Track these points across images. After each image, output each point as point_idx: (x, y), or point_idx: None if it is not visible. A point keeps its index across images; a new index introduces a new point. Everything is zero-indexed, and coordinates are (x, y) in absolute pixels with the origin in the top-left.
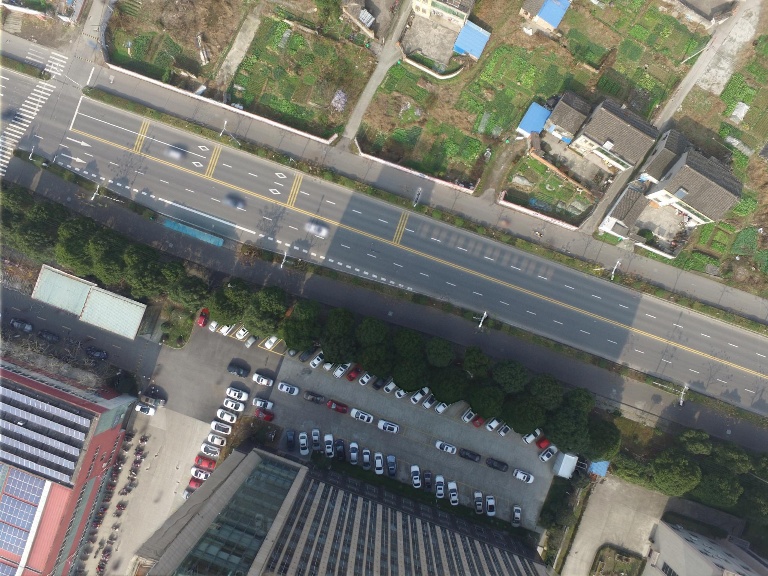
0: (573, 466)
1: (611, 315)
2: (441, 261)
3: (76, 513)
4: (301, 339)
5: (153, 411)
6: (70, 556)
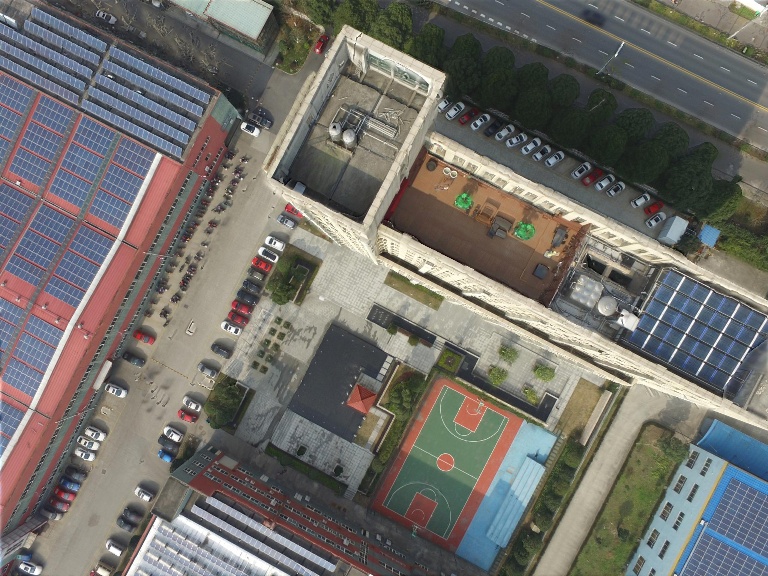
0: (683, 229)
1: (738, 89)
2: (570, 15)
3: (177, 203)
4: (428, 54)
5: (258, 132)
6: (161, 255)
